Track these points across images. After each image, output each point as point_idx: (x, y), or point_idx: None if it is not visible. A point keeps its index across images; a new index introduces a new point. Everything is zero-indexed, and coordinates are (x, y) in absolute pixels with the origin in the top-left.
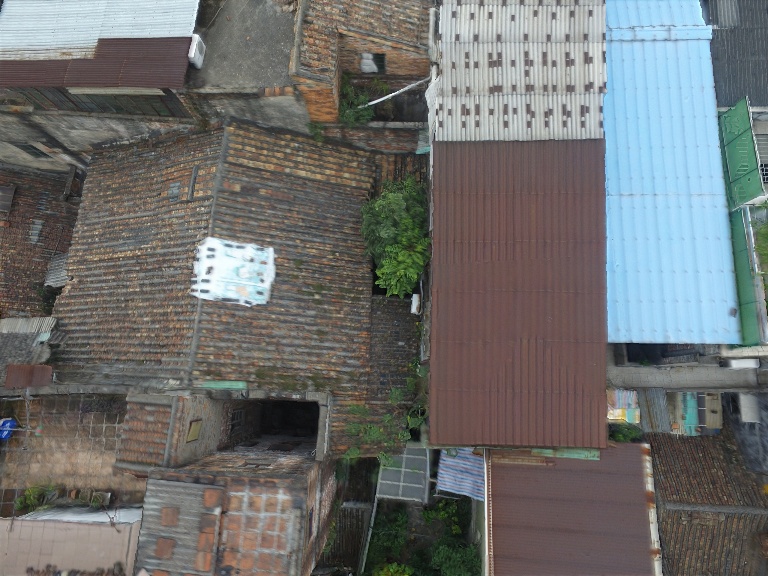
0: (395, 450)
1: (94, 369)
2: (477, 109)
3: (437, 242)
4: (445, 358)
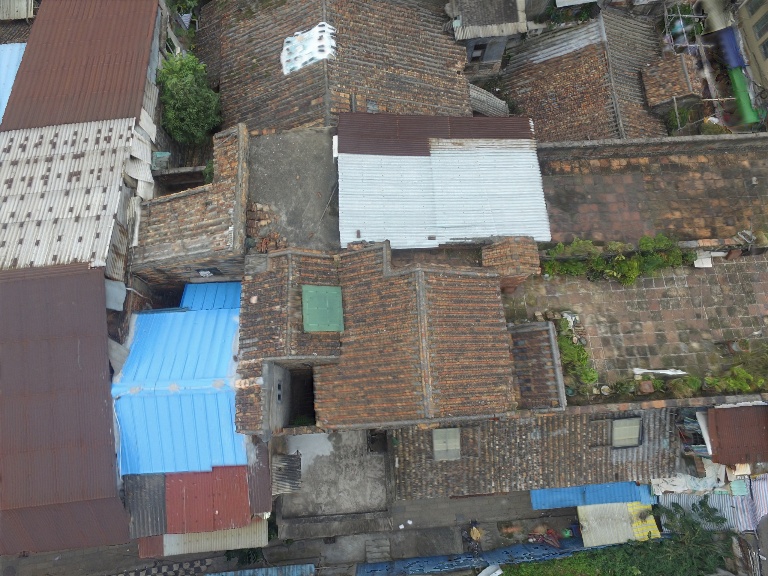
0: (207, 5)
1: (408, 2)
2: (97, 141)
3: (144, 61)
4: (147, 5)
